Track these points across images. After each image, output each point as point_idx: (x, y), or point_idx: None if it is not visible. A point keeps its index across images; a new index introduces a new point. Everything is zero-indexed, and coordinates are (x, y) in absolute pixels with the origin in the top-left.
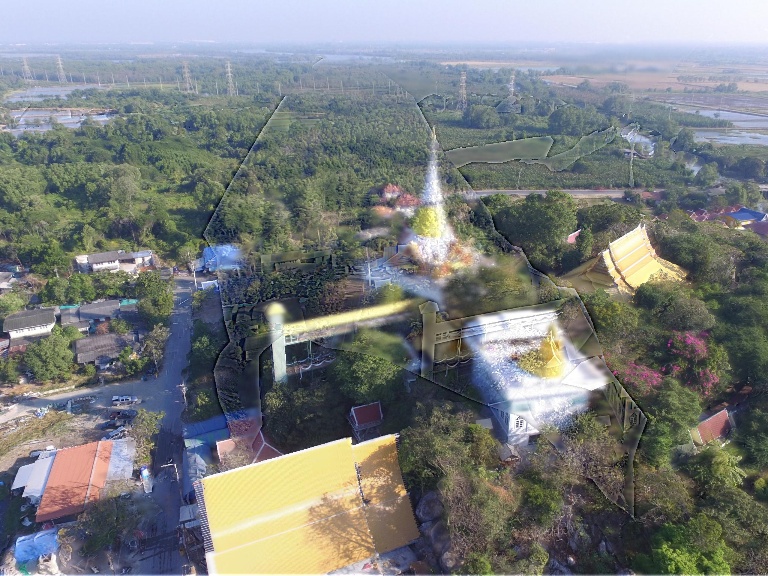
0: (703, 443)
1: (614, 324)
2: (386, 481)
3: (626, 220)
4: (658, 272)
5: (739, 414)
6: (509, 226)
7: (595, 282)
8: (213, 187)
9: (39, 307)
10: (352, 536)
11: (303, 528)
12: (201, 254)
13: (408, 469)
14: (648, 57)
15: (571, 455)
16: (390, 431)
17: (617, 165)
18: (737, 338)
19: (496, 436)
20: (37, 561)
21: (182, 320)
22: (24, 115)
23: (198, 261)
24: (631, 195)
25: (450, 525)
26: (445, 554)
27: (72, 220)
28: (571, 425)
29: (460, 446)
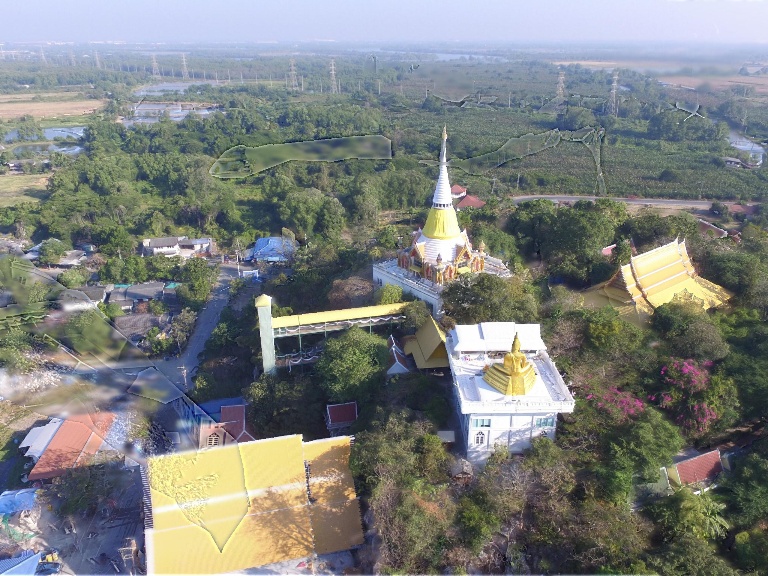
0: (681, 484)
1: (608, 344)
2: (336, 482)
3: (677, 234)
4: (682, 292)
5: (737, 457)
6: (541, 233)
7: (612, 298)
8: (280, 180)
9: (97, 284)
10: (293, 533)
11: (244, 518)
12: (255, 244)
13: (356, 473)
14: (714, 56)
15: (150, 470)
16: (353, 433)
17: (713, 174)
18: (751, 372)
19: (459, 450)
20: (19, 515)
21: (218, 306)
22: (138, 108)
23: (249, 251)
24: (718, 207)
25: (382, 535)
26: (376, 564)
27: (152, 206)
28: (149, 438)
29: (407, 456)
